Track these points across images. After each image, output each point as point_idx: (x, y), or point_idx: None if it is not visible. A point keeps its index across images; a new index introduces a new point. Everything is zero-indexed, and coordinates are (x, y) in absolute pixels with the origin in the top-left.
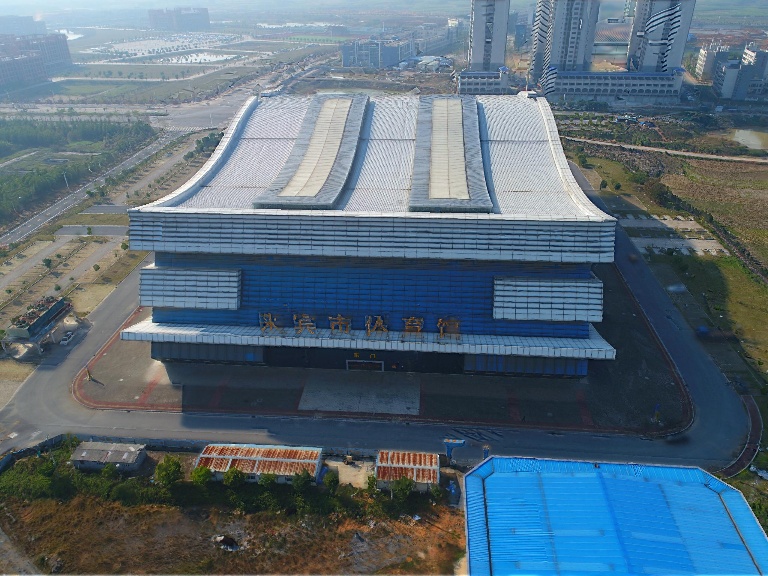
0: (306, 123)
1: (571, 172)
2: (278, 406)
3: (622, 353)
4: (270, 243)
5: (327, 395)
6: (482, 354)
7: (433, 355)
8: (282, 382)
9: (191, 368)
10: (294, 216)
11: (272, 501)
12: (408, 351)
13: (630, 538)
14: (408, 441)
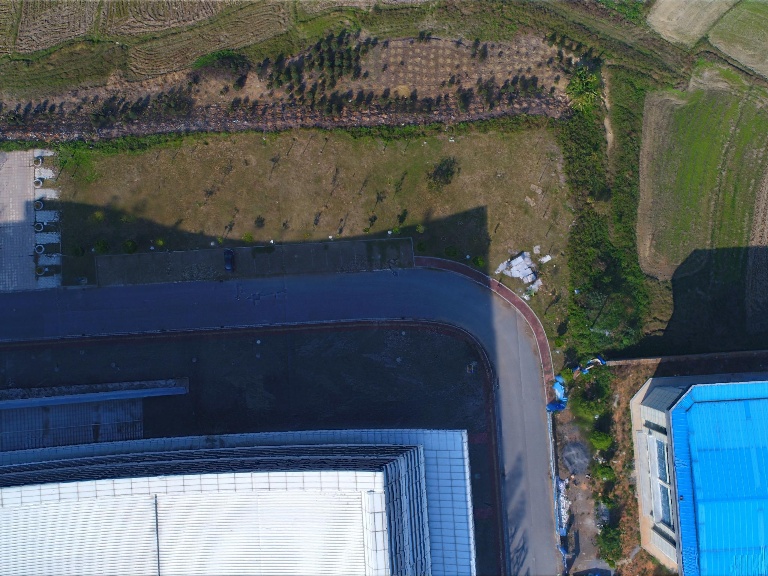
0: None
1: (78, 483)
2: None
3: (354, 378)
4: None
5: None
6: None
7: None
8: None
9: None
10: None
11: None
12: None
13: (763, 490)
14: None
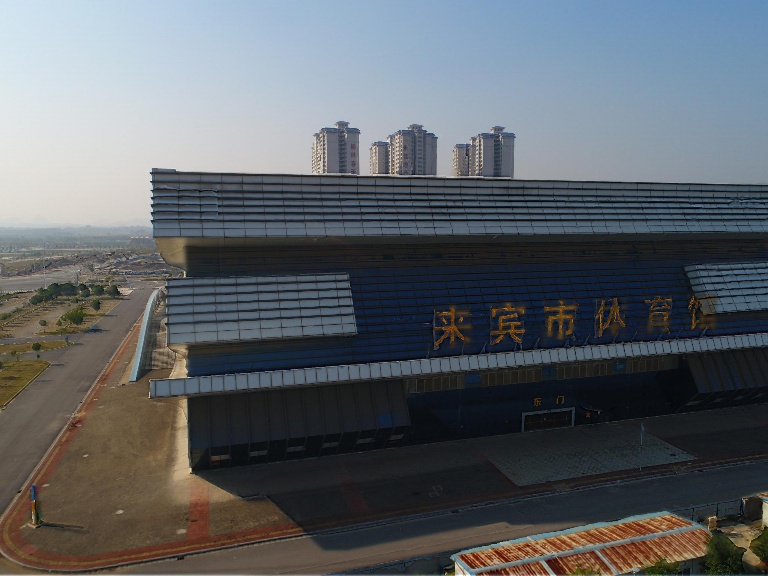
0: None
1: None
2: (481, 488)
3: None
4: (406, 219)
5: (537, 462)
6: (745, 348)
7: None
8: (445, 460)
9: (258, 471)
10: (436, 180)
11: None
12: (655, 356)
13: None
14: (740, 488)
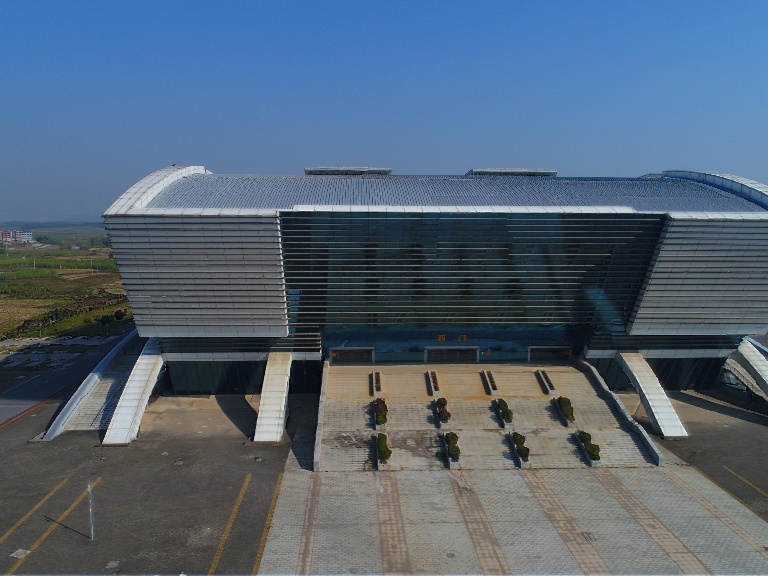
0: None
1: None
2: None
3: None
4: None
5: None
6: None
7: None
8: None
9: None
10: None
11: None
12: None
13: None
14: None
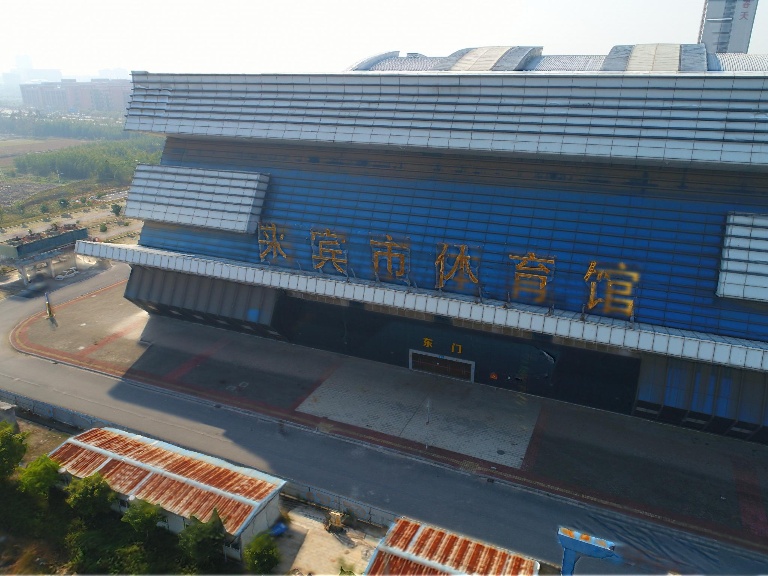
0: (445, 60)
1: None
2: (265, 398)
3: None
4: (309, 122)
5: (356, 399)
6: (684, 358)
7: (573, 364)
8: (294, 366)
9: (180, 326)
10: (353, 77)
11: (136, 566)
12: (515, 329)
13: None
14: (480, 516)
